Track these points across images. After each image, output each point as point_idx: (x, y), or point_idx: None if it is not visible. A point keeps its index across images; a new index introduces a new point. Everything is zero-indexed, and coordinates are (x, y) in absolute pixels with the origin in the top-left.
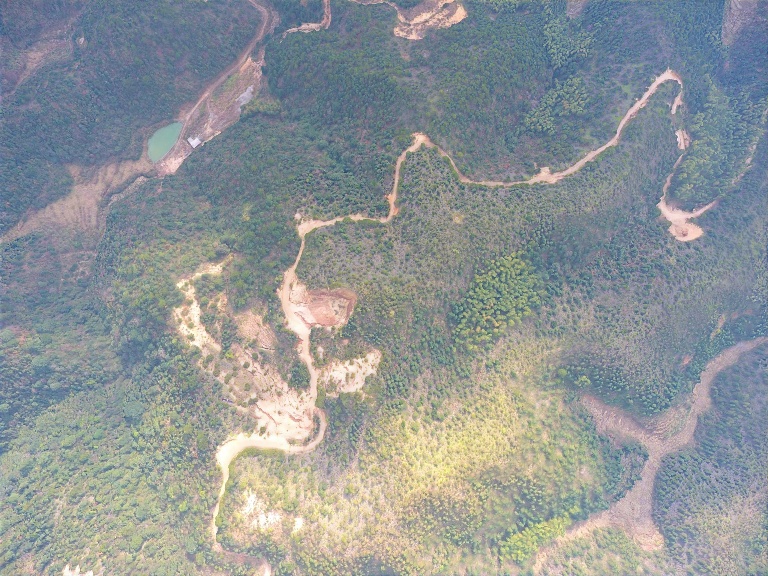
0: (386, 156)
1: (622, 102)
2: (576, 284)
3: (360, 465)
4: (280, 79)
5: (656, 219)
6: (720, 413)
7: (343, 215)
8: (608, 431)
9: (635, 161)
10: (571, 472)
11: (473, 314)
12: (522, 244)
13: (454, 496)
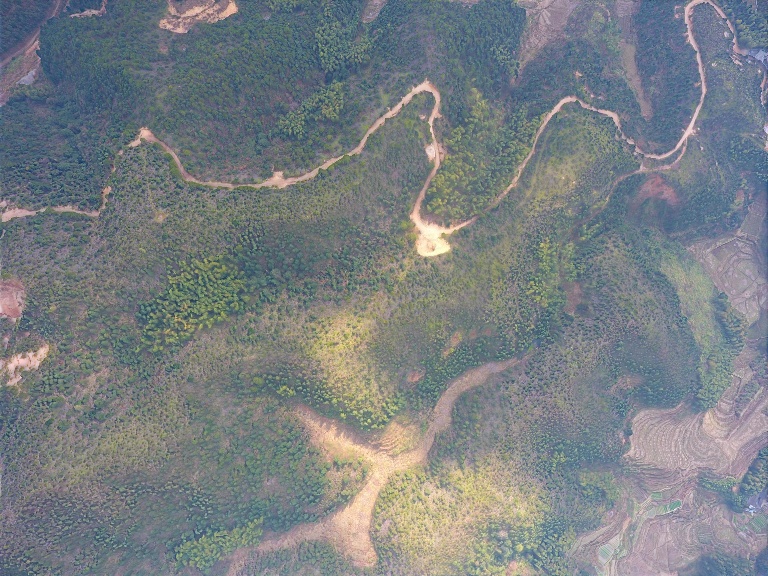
0: (106, 149)
1: (374, 111)
2: (296, 292)
3: (4, 460)
4: (51, 64)
5: (407, 232)
6: (455, 433)
7: (50, 206)
8: (324, 443)
9: (371, 171)
10: (251, 482)
11: (165, 315)
12: (227, 248)
13: (90, 498)
